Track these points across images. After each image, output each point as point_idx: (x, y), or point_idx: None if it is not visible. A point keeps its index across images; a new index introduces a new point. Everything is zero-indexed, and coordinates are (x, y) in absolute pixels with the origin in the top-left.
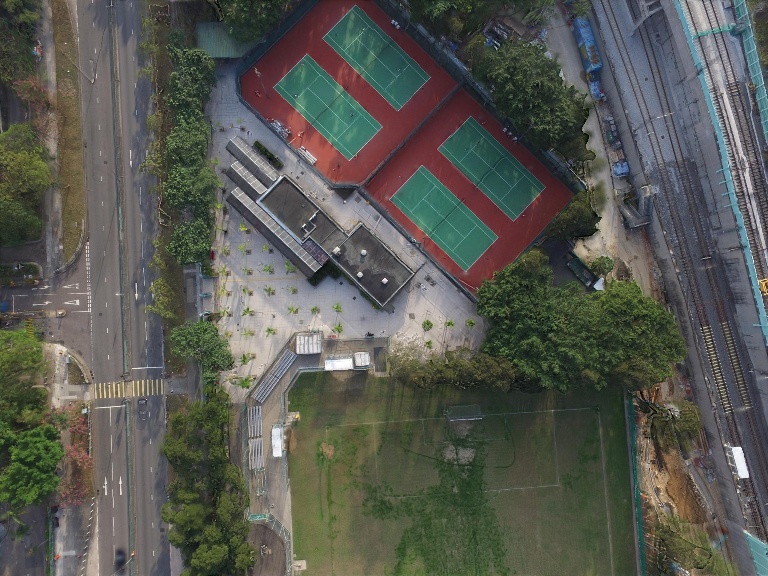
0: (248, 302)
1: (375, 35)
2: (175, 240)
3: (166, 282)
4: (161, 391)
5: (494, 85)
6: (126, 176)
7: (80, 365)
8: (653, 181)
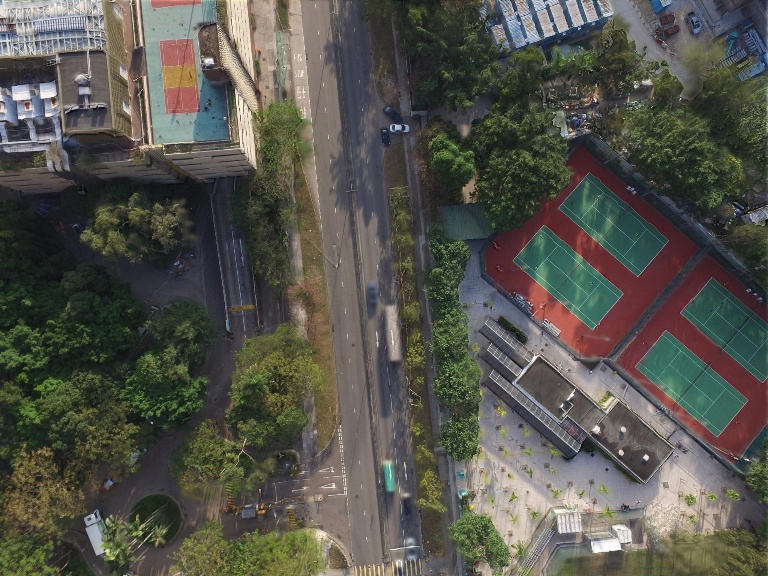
0: (501, 478)
1: (611, 202)
2: (450, 437)
3: (435, 473)
4: (420, 571)
5: (767, 267)
6: (373, 357)
7: (341, 550)
8: None
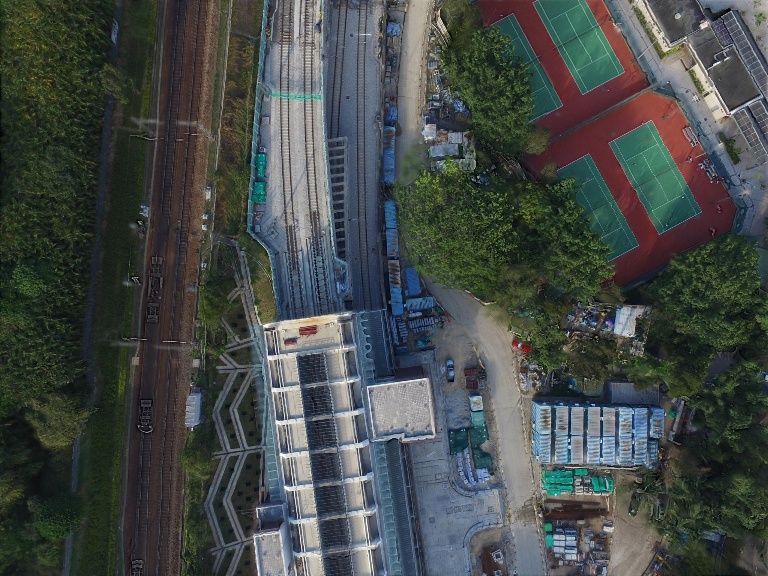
0: None
1: None
2: None
3: None
4: None
5: None
6: None
7: None
8: None
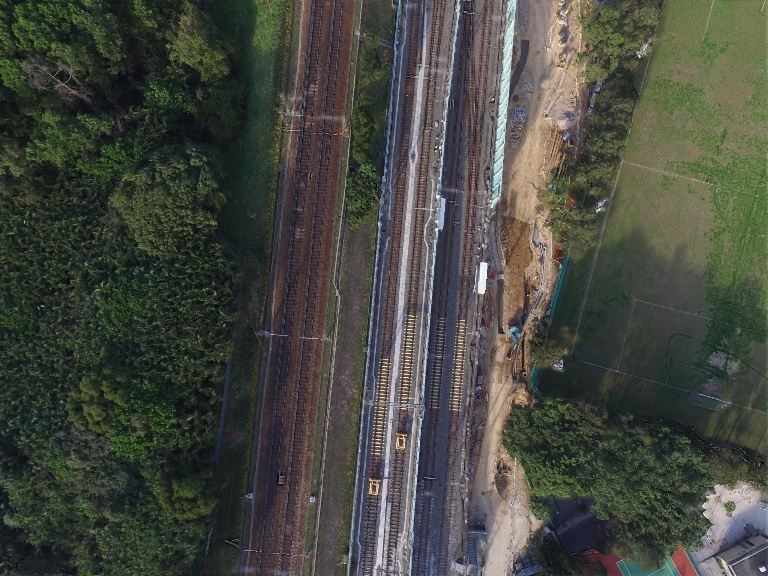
0: None
1: None
2: None
3: None
4: None
5: None
6: None
7: None
8: (455, 575)
